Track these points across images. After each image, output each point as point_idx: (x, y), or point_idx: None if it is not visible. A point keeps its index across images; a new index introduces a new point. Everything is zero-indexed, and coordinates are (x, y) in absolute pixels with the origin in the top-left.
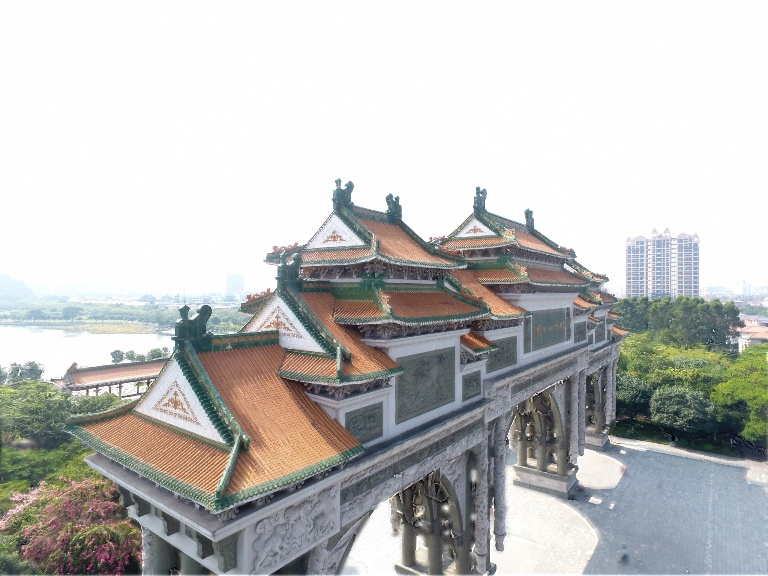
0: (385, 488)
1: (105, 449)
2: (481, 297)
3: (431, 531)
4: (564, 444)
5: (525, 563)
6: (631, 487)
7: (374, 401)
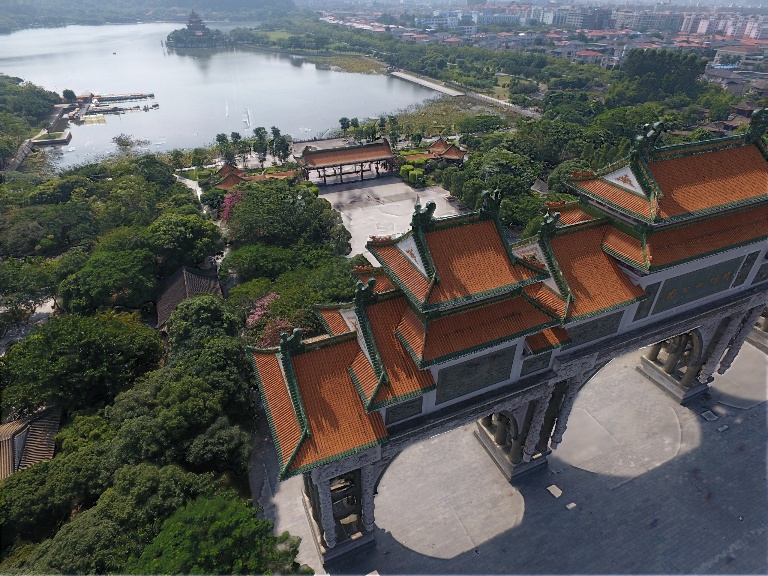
0: (423, 436)
1: (259, 383)
2: (556, 309)
3: (499, 419)
4: (698, 363)
5: (589, 450)
6: None
7: (414, 398)
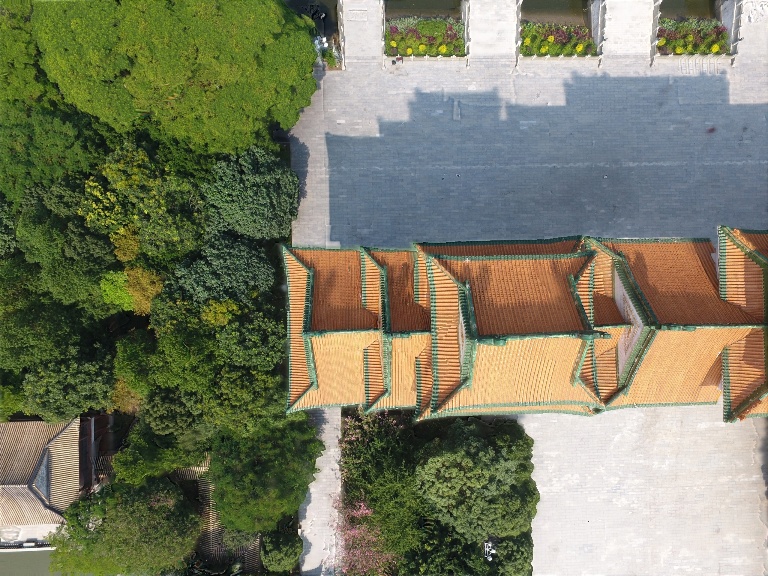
0: None
1: None
2: None
3: None
4: None
5: None
6: (476, 236)
7: None
